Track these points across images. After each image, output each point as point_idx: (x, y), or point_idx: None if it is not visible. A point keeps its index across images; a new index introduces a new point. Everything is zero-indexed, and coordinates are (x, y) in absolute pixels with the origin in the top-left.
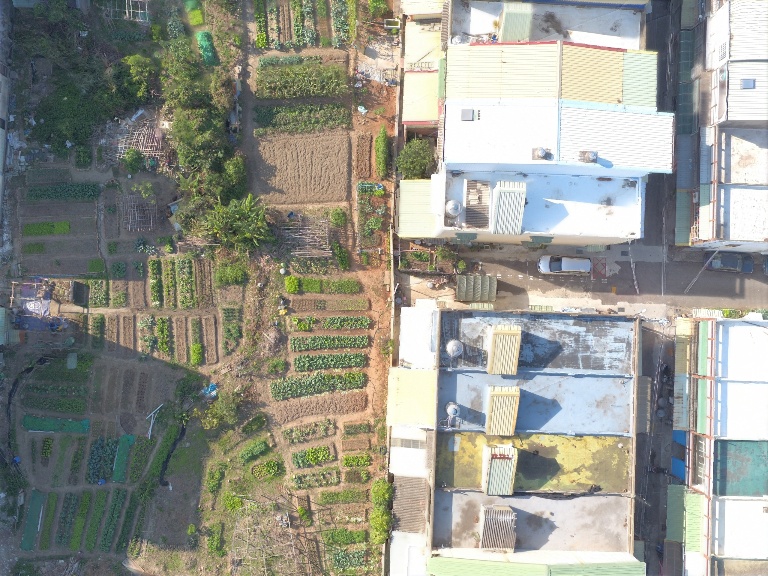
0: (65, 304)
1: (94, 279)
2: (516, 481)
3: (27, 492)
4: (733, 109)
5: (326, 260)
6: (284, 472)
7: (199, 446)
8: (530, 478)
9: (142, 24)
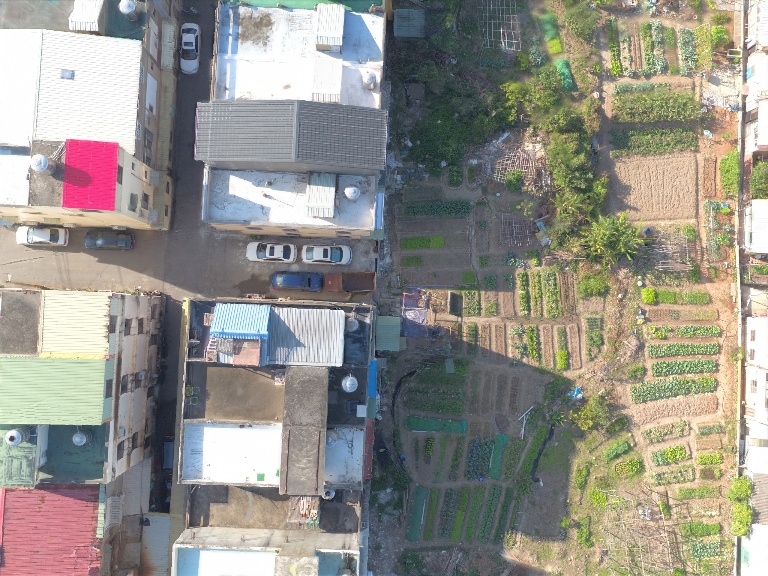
0: (441, 313)
1: (467, 290)
2: None
3: (411, 487)
4: None
5: (678, 273)
6: (644, 469)
7: (566, 445)
8: None
9: (507, 52)
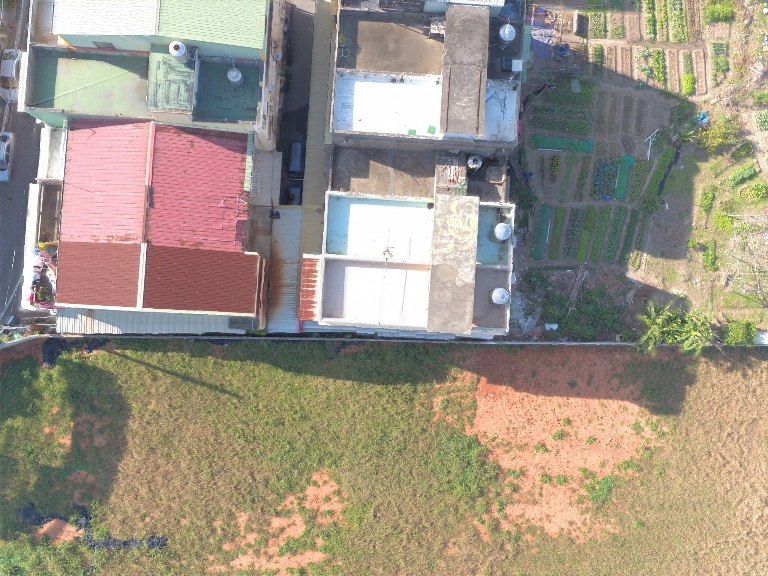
0: (566, 34)
1: (593, 12)
2: None
3: (536, 206)
4: None
5: None
6: None
7: (691, 169)
8: None
9: None
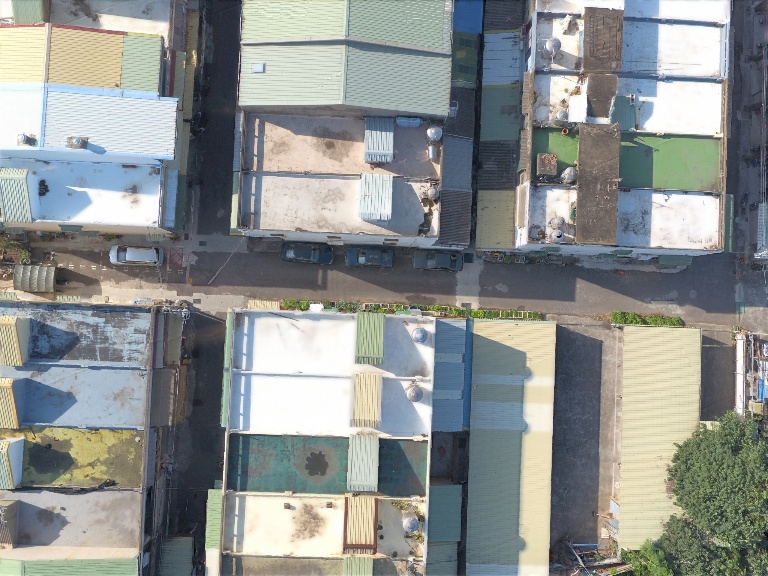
0: None
1: None
2: (27, 475)
3: None
4: (244, 94)
5: None
6: None
7: None
8: (42, 472)
9: None
